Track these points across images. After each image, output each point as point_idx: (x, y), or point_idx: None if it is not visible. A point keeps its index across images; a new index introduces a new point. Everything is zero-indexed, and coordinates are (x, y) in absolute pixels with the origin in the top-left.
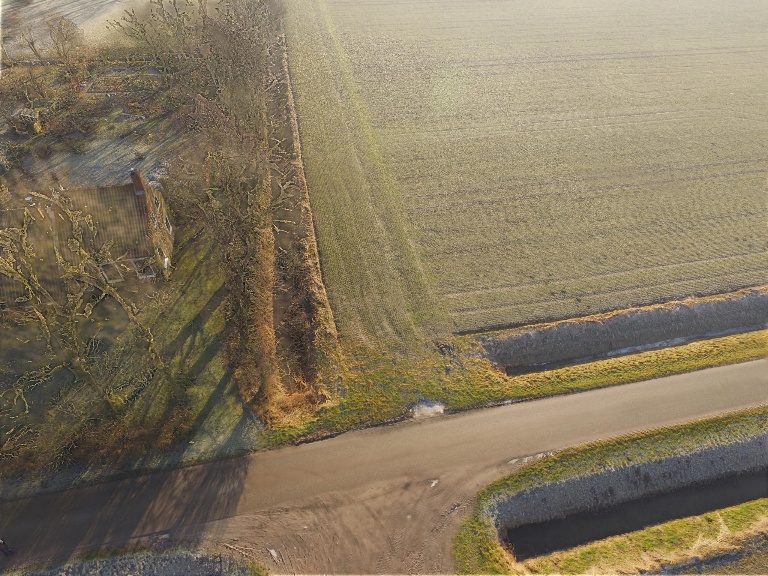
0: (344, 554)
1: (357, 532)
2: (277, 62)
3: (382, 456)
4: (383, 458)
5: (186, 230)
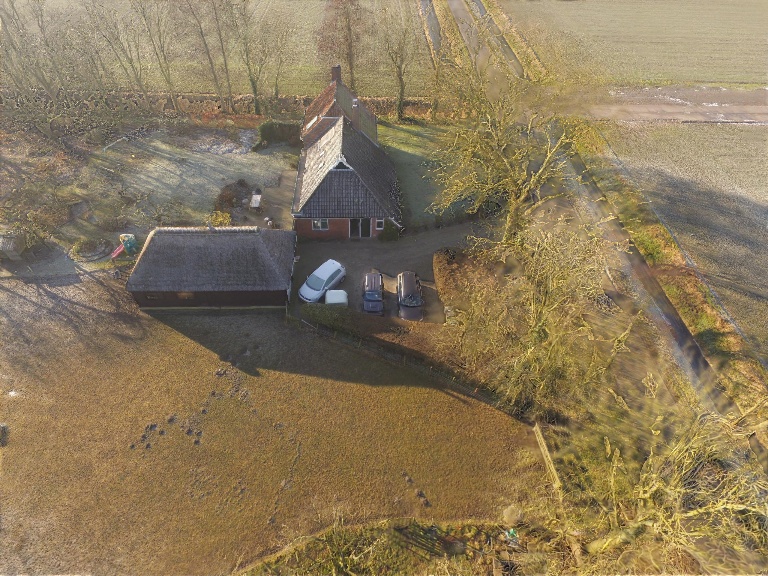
0: None
1: None
2: None
3: None
4: None
5: None
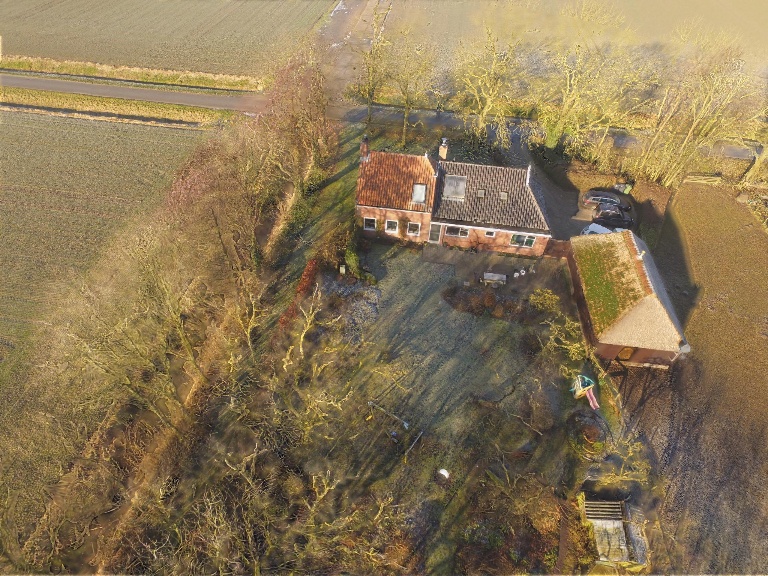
0: None
1: None
2: None
3: None
4: None
5: None
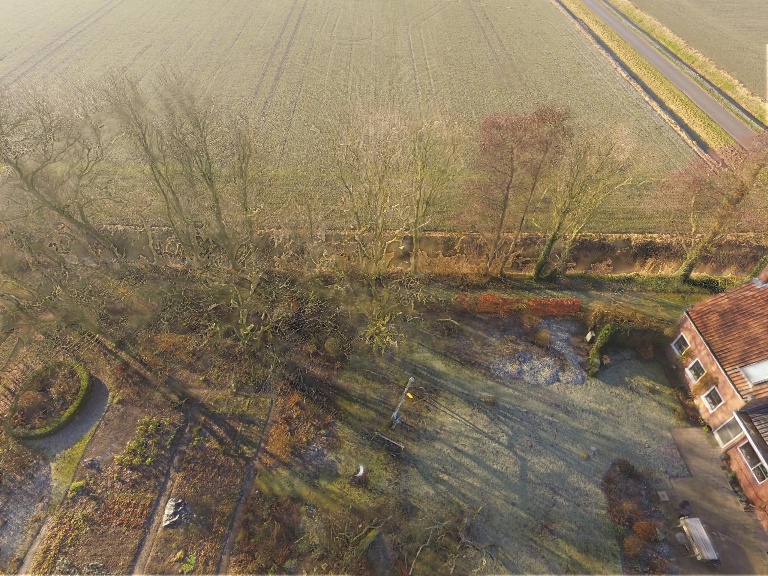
0: None
1: None
2: (124, 244)
3: None
4: None
5: None
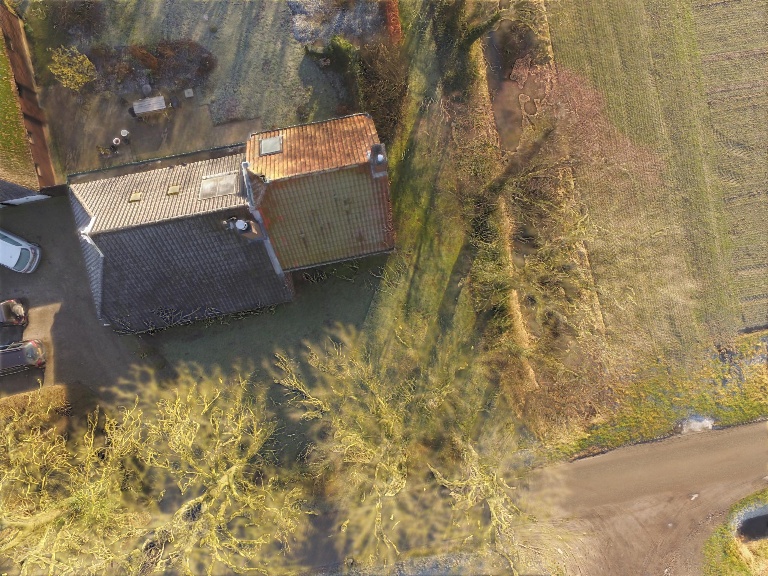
0: (617, 554)
1: (627, 538)
2: None
3: (650, 473)
4: (651, 475)
5: (387, 144)
